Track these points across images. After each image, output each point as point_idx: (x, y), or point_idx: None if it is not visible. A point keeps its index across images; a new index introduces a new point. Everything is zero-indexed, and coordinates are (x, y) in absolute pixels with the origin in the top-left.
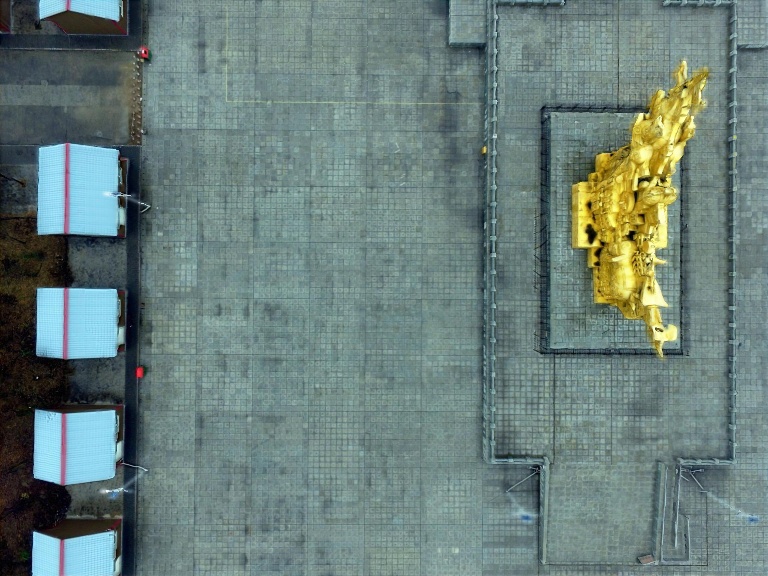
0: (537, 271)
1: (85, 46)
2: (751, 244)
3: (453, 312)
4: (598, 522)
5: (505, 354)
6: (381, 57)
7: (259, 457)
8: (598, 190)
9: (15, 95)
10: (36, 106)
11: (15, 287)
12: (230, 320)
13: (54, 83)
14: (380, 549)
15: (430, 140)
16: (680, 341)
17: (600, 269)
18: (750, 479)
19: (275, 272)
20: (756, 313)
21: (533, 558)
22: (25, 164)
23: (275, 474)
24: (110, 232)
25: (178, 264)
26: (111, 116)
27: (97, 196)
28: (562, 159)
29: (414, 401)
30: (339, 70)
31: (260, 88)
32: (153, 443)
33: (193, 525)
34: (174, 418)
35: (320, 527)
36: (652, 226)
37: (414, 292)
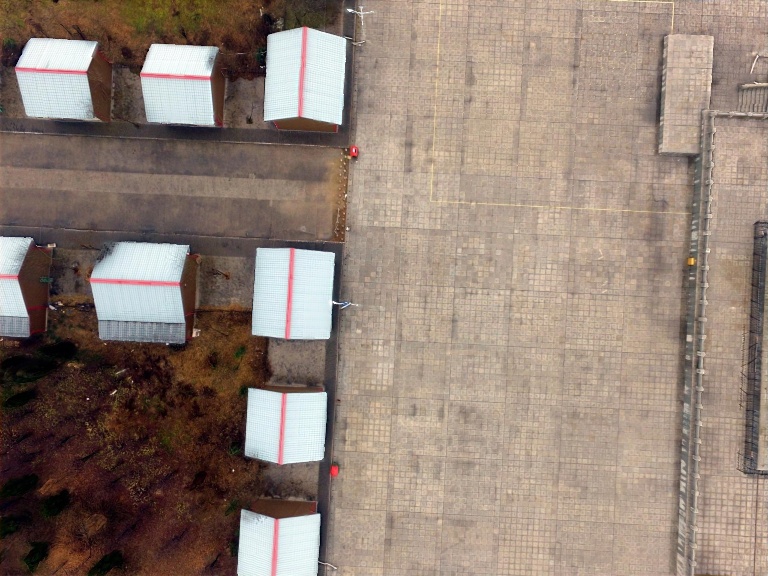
0: (743, 389)
1: (294, 141)
2: None
3: (651, 424)
4: None
5: (707, 472)
6: (588, 162)
7: (448, 561)
8: None
9: (223, 187)
10: (242, 199)
11: (215, 379)
12: (425, 421)
13: (261, 177)
14: None
15: (634, 248)
16: None
17: None
18: None
19: (472, 374)
20: None
21: None
22: (230, 256)
23: None
24: (324, 335)
25: (375, 362)
26: (315, 211)
27: (315, 300)
28: None
29: (607, 512)
30: (545, 174)
31: (465, 189)
32: (343, 541)
33: None
34: (365, 517)
35: None
36: None
37: (612, 401)
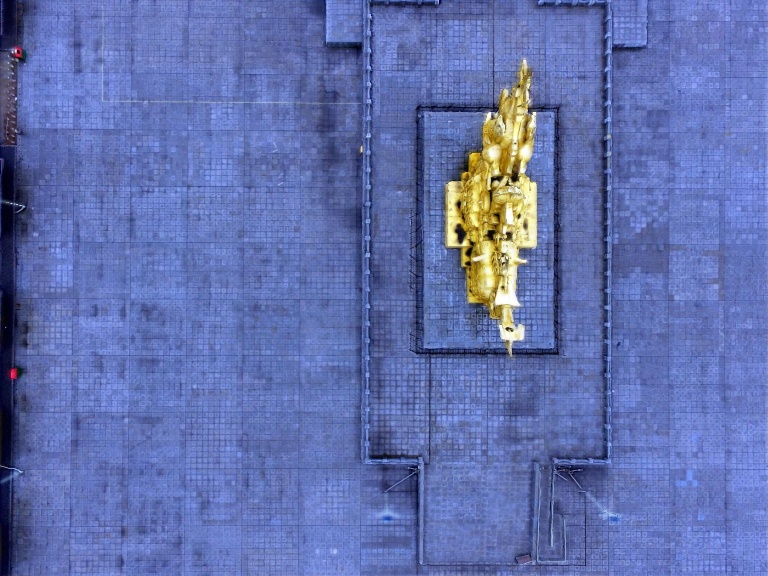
0: (413, 271)
1: None
2: (630, 243)
3: (331, 312)
4: (476, 522)
5: (381, 354)
6: (258, 56)
7: (136, 458)
8: (464, 189)
9: None
10: None
11: None
12: (106, 321)
13: None
14: (258, 550)
15: (308, 140)
16: (554, 340)
17: (471, 269)
18: (629, 478)
19: (152, 273)
20: (635, 312)
21: (411, 558)
22: None
23: (152, 475)
24: None
25: (54, 265)
26: None
27: None
28: (435, 159)
29: (292, 402)
30: (216, 70)
31: (136, 88)
32: (29, 445)
33: (69, 527)
34: (50, 420)
35: (197, 528)
36: (505, 225)
37: (292, 292)
